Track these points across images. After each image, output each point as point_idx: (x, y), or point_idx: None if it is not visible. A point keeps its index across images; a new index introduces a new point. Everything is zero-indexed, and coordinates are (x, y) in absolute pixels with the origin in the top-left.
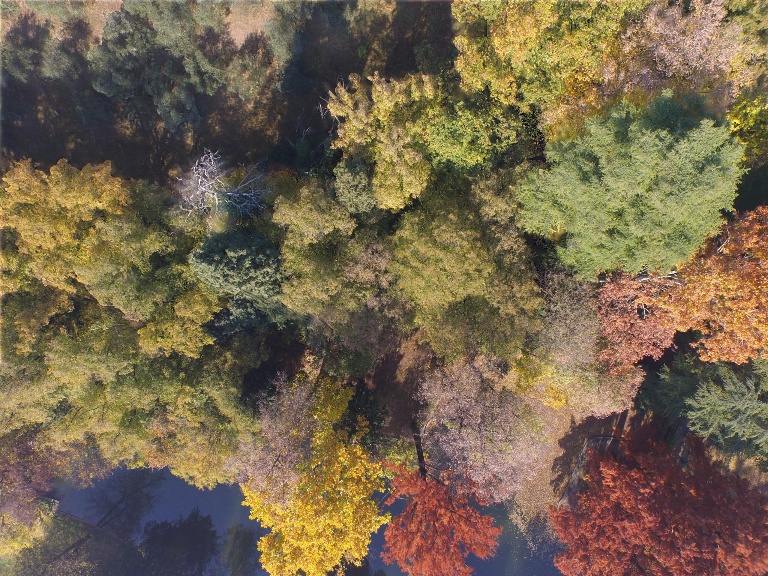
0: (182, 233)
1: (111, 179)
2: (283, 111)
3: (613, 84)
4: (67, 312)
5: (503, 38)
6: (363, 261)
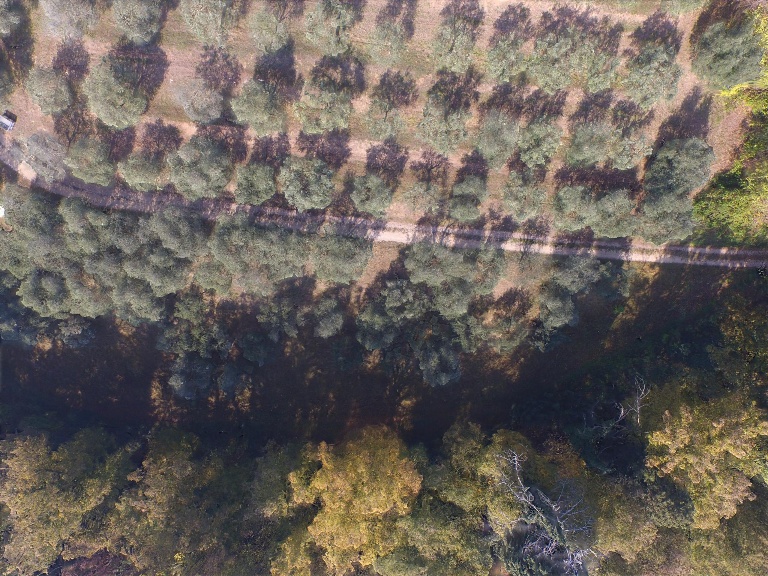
0: (452, 503)
1: (415, 476)
2: (527, 354)
3: None
4: (328, 575)
5: None
6: (669, 575)
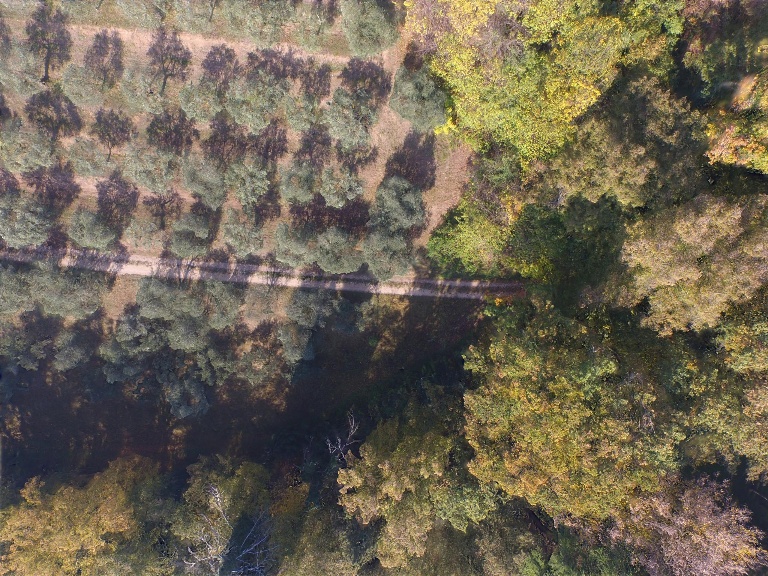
0: None
1: (116, 513)
2: (291, 385)
3: (620, 542)
4: None
5: (514, 463)
6: None
